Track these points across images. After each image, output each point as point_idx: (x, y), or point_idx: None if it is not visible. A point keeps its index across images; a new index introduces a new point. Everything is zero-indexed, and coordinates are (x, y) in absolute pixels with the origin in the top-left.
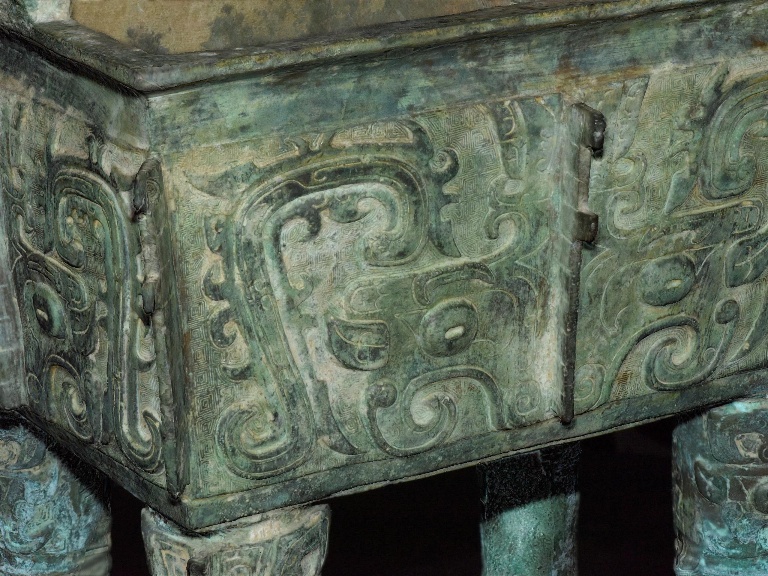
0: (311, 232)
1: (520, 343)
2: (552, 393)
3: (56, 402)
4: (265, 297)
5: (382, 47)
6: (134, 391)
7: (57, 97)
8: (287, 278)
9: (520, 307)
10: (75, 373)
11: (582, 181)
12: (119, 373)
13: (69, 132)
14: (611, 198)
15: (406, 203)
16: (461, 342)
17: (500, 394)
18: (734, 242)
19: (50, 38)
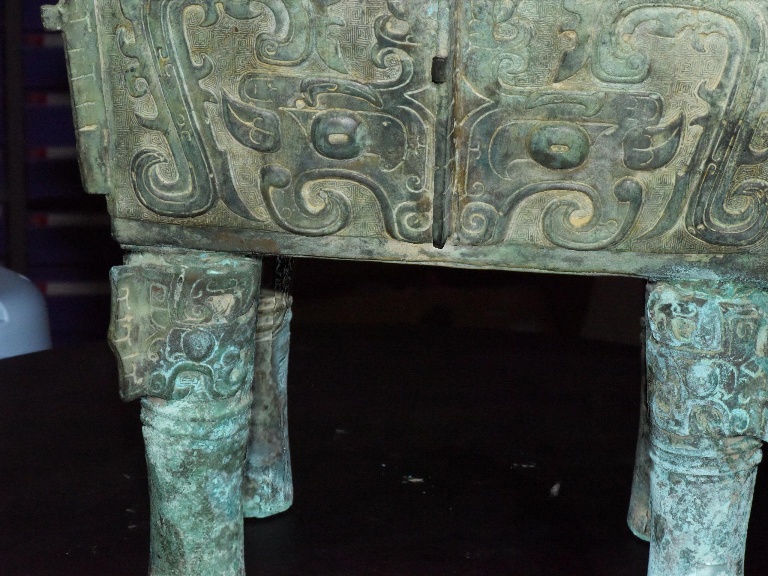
0: None
1: None
2: None
3: None
4: None
5: None
6: None
7: None
8: None
9: None
10: None
11: None
12: None
13: None
14: None
15: None
16: None
17: None
18: None
19: None
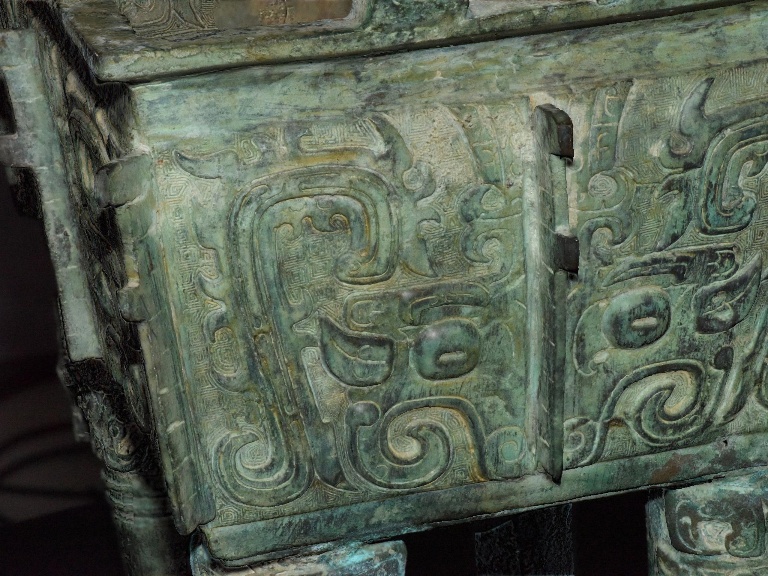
0: None
1: None
2: None
3: None
4: None
5: None
6: None
7: None
8: None
9: None
10: None
11: None
12: None
13: None
14: None
15: None
16: None
17: None
18: None
19: None
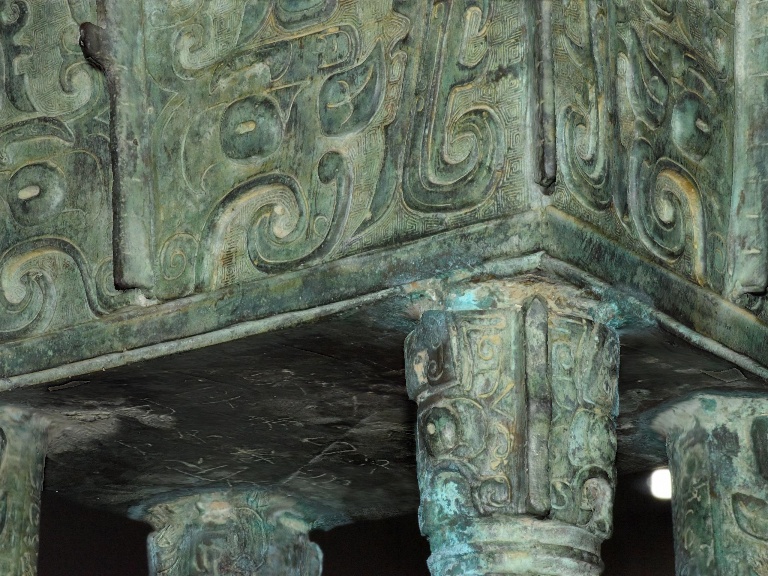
0: None
1: (110, 212)
2: None
3: None
4: None
5: None
6: None
7: None
8: None
9: (104, 170)
10: None
11: None
12: None
13: None
14: (176, 35)
15: None
16: (37, 204)
17: (89, 270)
18: (325, 78)
19: None
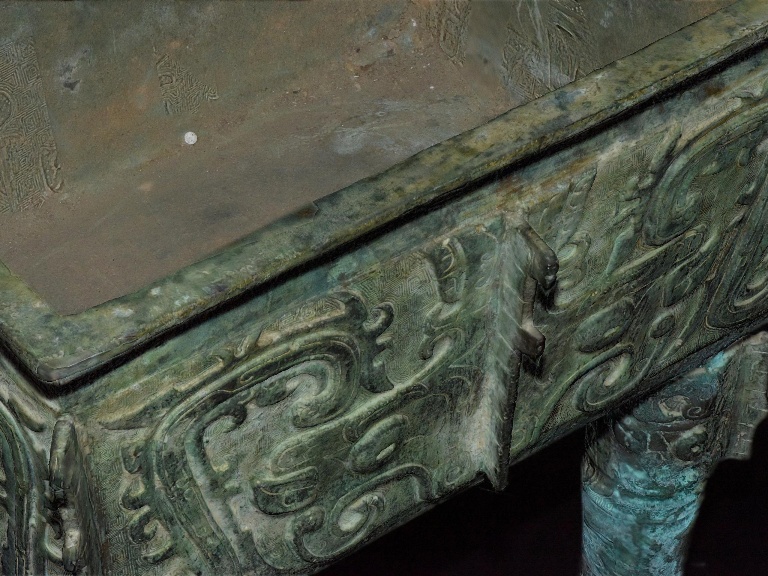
0: (236, 423)
1: (451, 427)
2: (483, 457)
3: None
4: (187, 490)
5: (316, 255)
6: (42, 569)
7: None
8: (210, 466)
9: (452, 400)
10: None
11: (527, 302)
12: (24, 550)
13: None
14: None
15: (338, 368)
16: (392, 456)
17: (430, 476)
18: (674, 269)
19: None
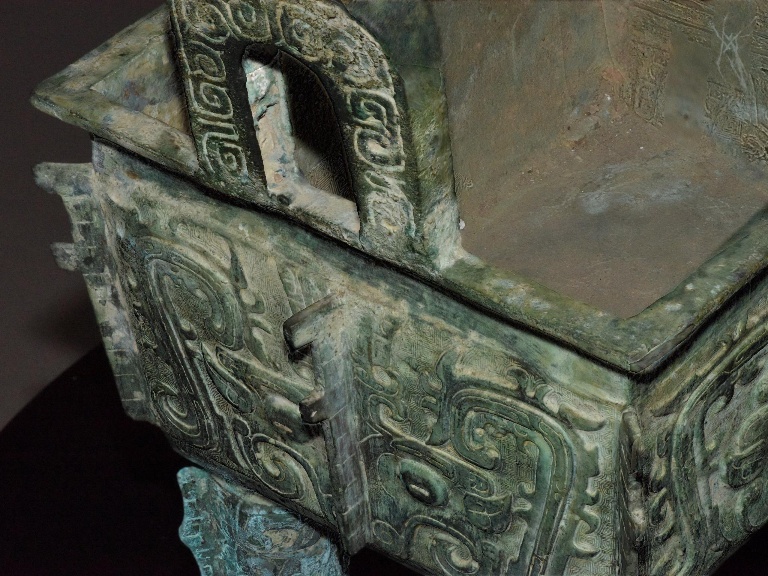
0: (726, 403)
1: None
2: None
3: (418, 547)
4: (690, 470)
5: None
6: (563, 569)
7: (448, 318)
8: None
9: None
10: (465, 540)
11: None
12: (544, 555)
13: (477, 357)
14: None
15: None
16: None
17: None
18: None
19: (477, 294)
